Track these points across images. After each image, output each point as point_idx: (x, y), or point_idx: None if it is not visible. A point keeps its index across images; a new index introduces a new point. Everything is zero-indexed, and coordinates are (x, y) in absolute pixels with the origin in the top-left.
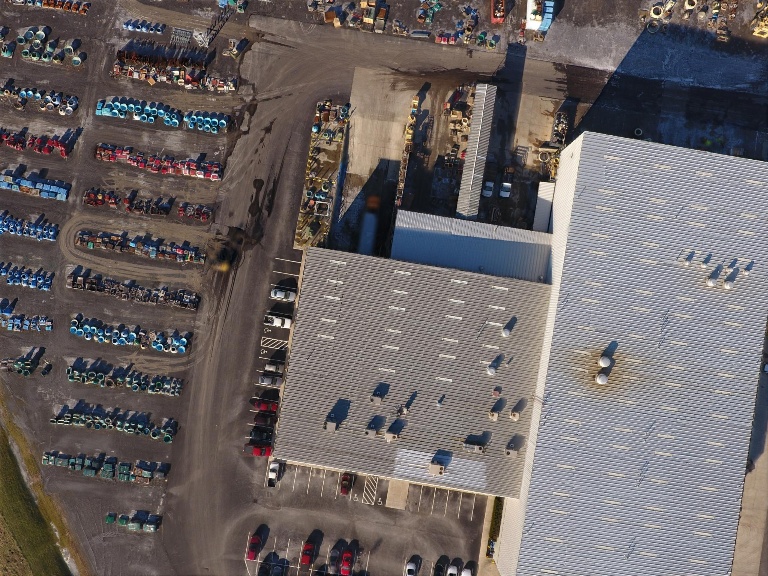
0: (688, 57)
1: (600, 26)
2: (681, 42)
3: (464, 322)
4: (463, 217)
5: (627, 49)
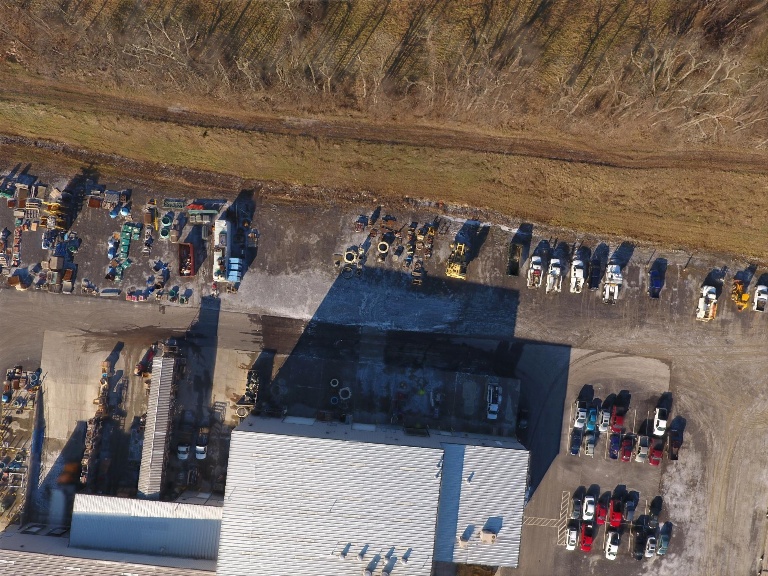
0: (385, 300)
1: (294, 273)
2: (377, 285)
3: None
4: (143, 496)
5: (323, 296)
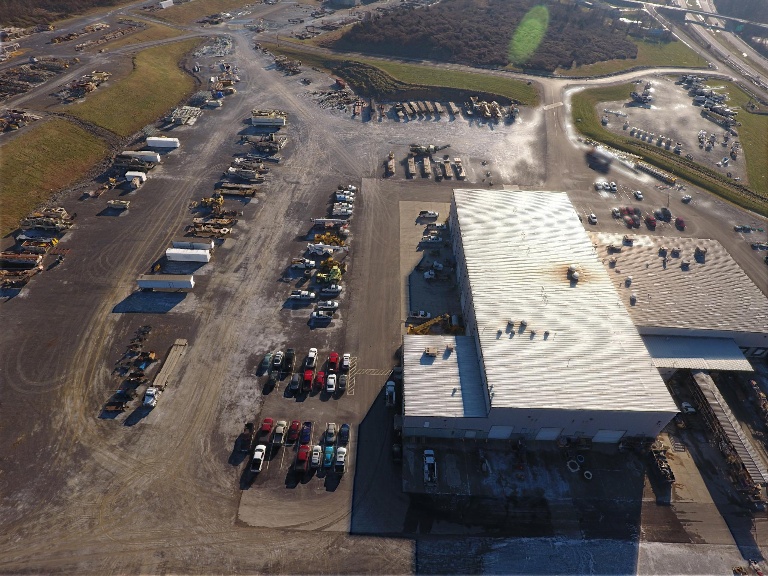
0: (570, 573)
1: None
2: None
3: (663, 302)
4: (703, 371)
5: (640, 573)
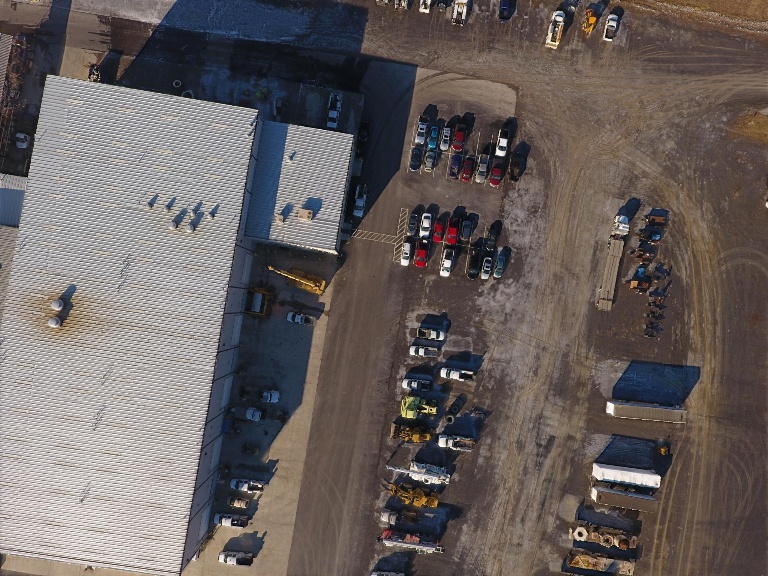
0: (234, 10)
1: None
2: None
3: None
4: None
5: (173, 2)
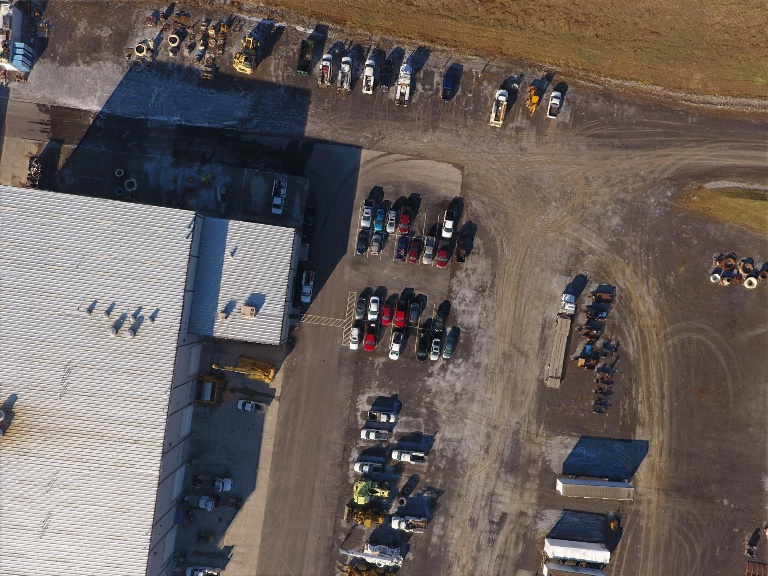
0: (175, 95)
1: (85, 65)
2: (168, 80)
3: None
4: None
5: (113, 88)
